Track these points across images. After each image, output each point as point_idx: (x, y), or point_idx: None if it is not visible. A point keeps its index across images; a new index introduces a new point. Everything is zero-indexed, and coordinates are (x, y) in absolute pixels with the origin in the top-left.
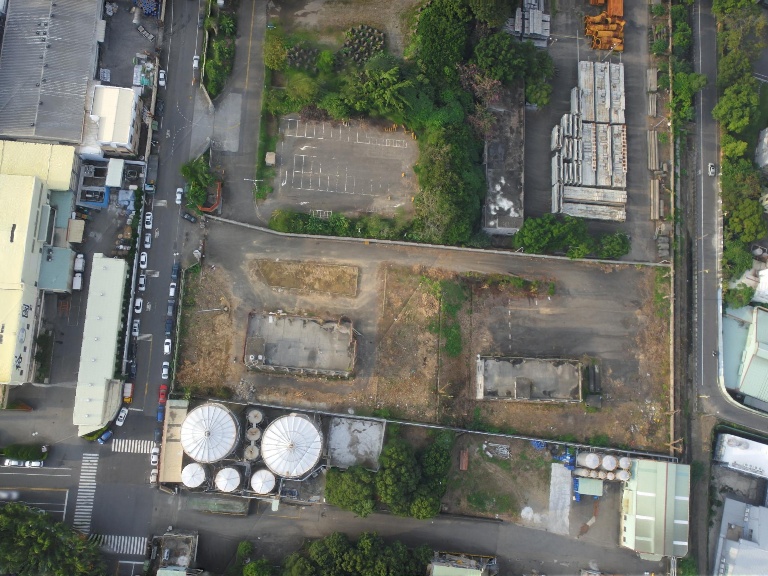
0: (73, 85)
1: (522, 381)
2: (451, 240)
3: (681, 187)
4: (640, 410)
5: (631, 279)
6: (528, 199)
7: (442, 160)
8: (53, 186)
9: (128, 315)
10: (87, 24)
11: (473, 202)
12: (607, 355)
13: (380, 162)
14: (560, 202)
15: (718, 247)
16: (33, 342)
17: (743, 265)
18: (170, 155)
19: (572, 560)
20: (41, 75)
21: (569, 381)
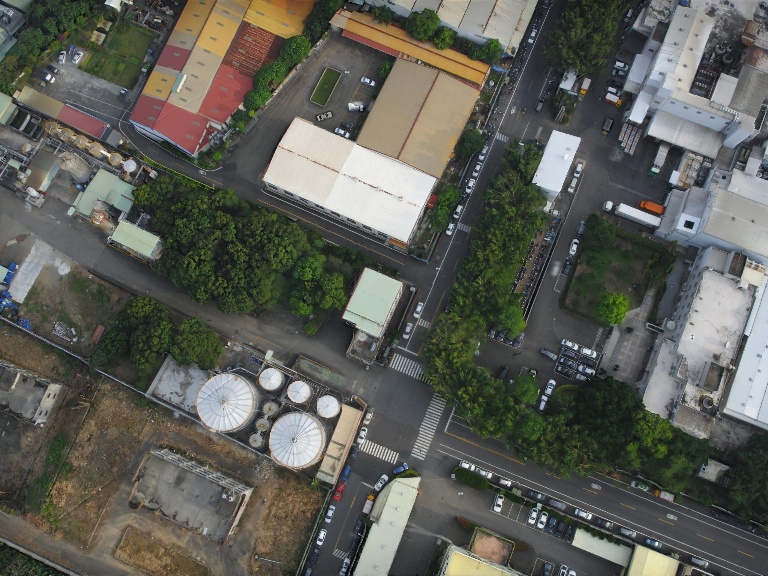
0: None
1: (5, 387)
2: (8, 555)
3: None
4: None
5: None
6: None
7: None
8: None
9: None
10: None
11: None
12: None
13: None
14: None
15: None
16: None
17: None
18: None
19: (44, 218)
20: None
21: None
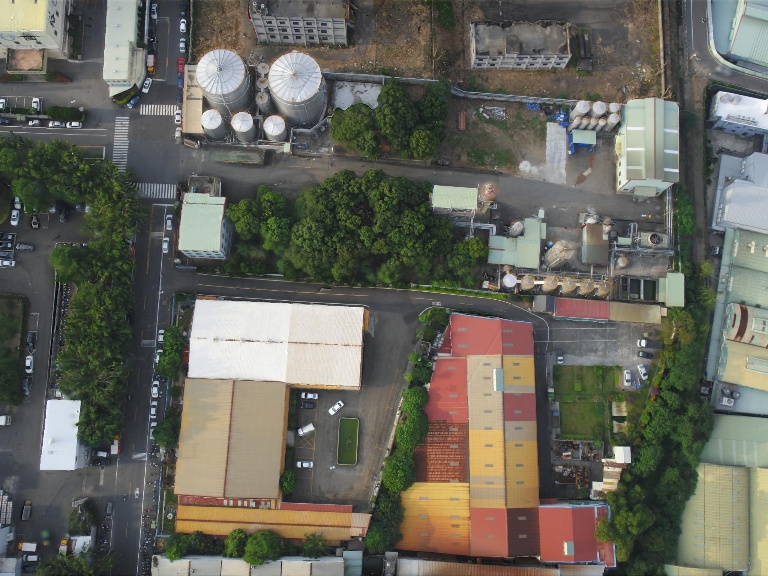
0: None
1: (511, 38)
2: None
3: None
4: (631, 73)
5: None
6: None
7: None
8: None
9: None
10: None
11: None
12: (596, 25)
13: None
14: None
15: None
16: (65, 18)
17: None
18: None
19: (570, 205)
20: None
21: (557, 40)
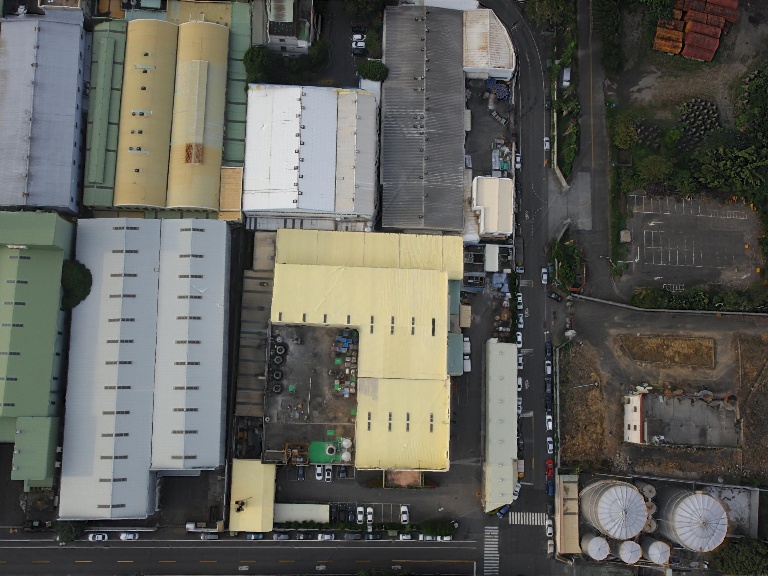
0: (451, 176)
1: None
2: None
3: None
4: None
5: None
6: None
7: None
8: None
9: None
10: (456, 115)
11: None
12: None
13: (723, 234)
14: None
15: None
16: None
17: None
18: (531, 236)
19: None
20: (423, 168)
21: None
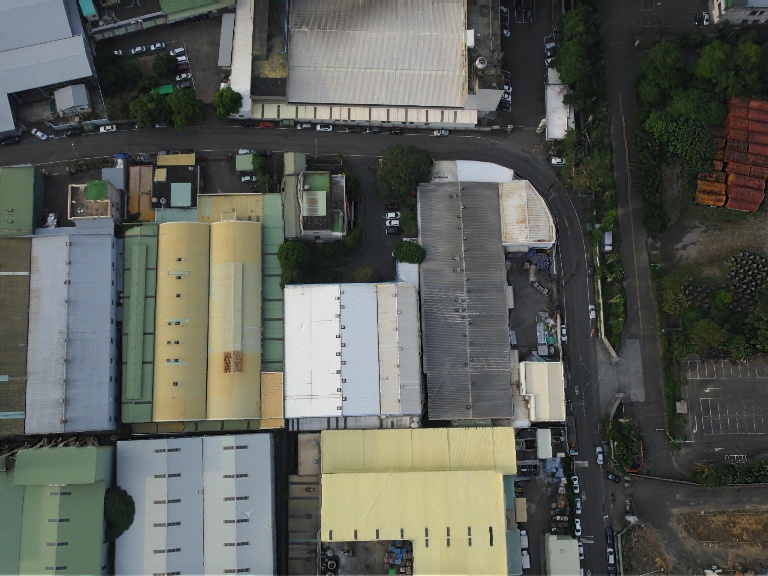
0: (497, 360)
1: None
2: None
3: None
4: None
5: None
6: None
7: None
8: (502, 471)
9: None
10: (498, 294)
11: None
12: None
13: None
14: None
15: None
16: None
17: None
18: (583, 412)
19: None
20: (468, 354)
21: None
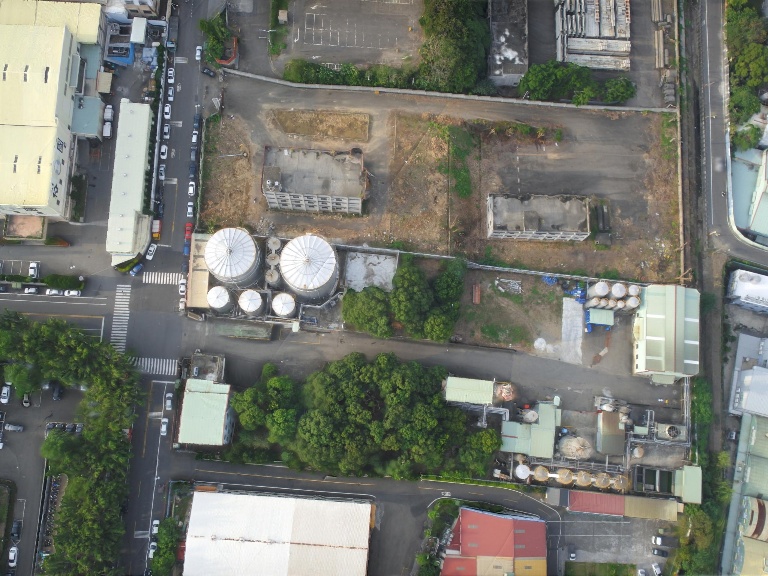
0: None
1: (530, 214)
2: (458, 86)
3: (686, 38)
4: (650, 247)
5: (637, 125)
6: (532, 49)
7: (446, 8)
8: (82, 39)
9: (154, 159)
10: None
11: (478, 49)
12: (615, 196)
13: (387, 18)
14: (564, 51)
15: (725, 94)
16: (68, 181)
17: (750, 108)
18: (189, 17)
19: (586, 387)
20: None
21: (577, 215)
